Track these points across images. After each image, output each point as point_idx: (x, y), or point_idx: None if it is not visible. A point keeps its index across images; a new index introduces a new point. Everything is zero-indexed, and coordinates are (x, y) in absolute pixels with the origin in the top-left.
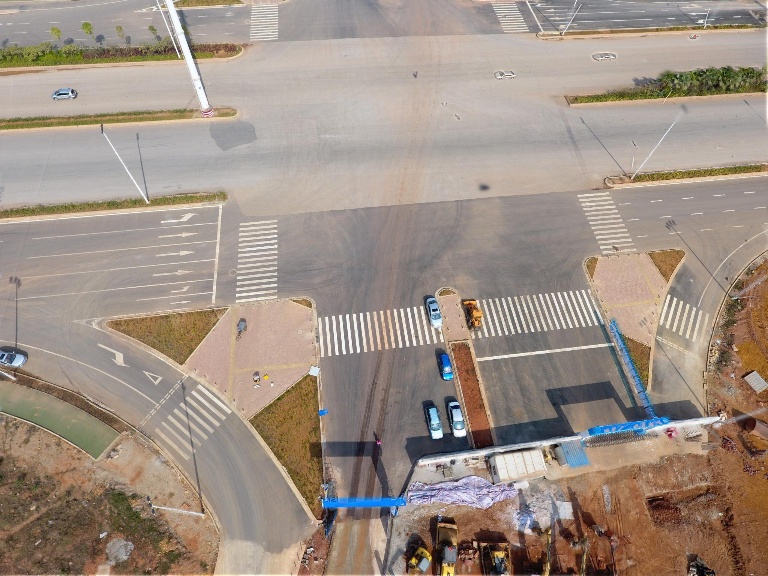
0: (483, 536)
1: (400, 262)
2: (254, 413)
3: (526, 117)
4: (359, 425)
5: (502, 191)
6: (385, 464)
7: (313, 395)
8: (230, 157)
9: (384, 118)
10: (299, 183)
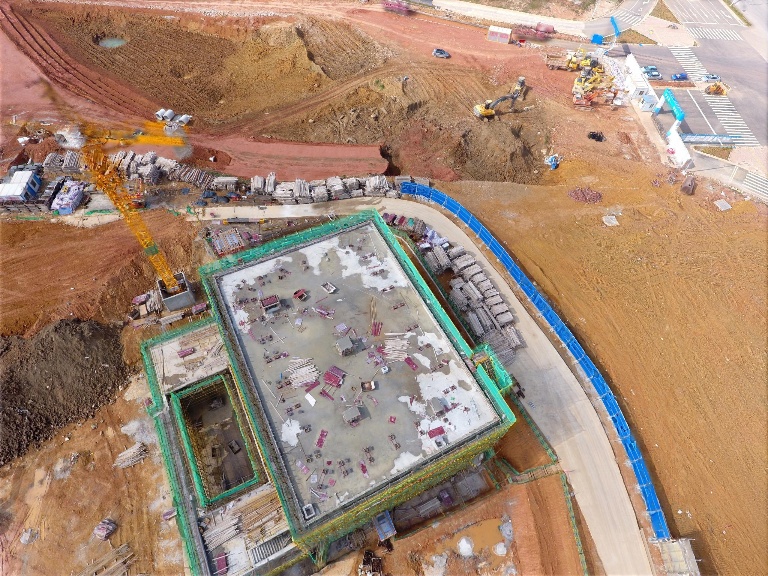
0: None
1: (739, 75)
2: None
3: None
4: (638, 53)
5: None
6: None
7: (648, 43)
8: None
9: None
10: None
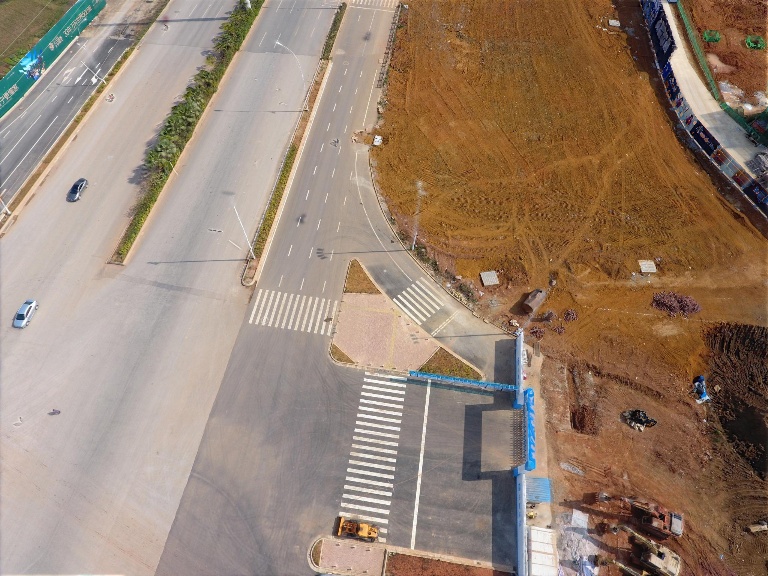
0: None
1: None
2: None
3: (110, 323)
4: None
5: (203, 408)
6: None
7: None
8: None
9: None
10: None
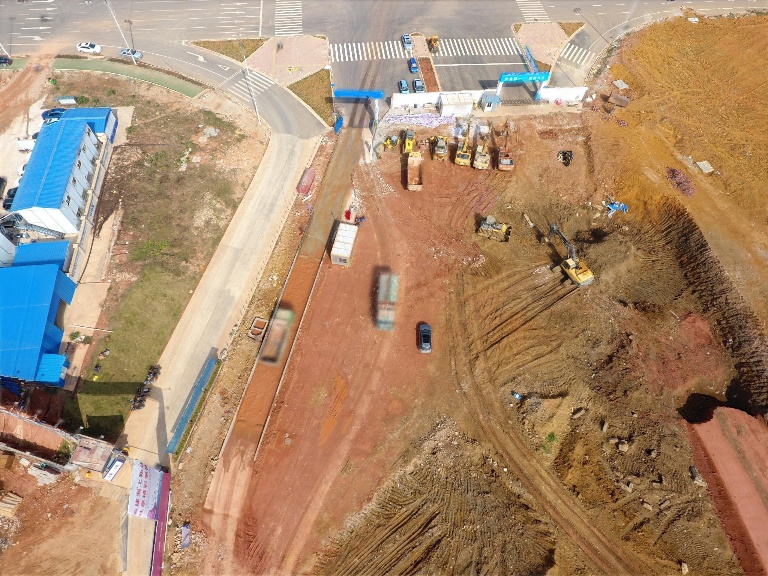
0: None
1: (385, 20)
2: (289, 84)
3: None
4: None
5: None
6: (372, 107)
7: (327, 77)
8: None
9: None
10: None
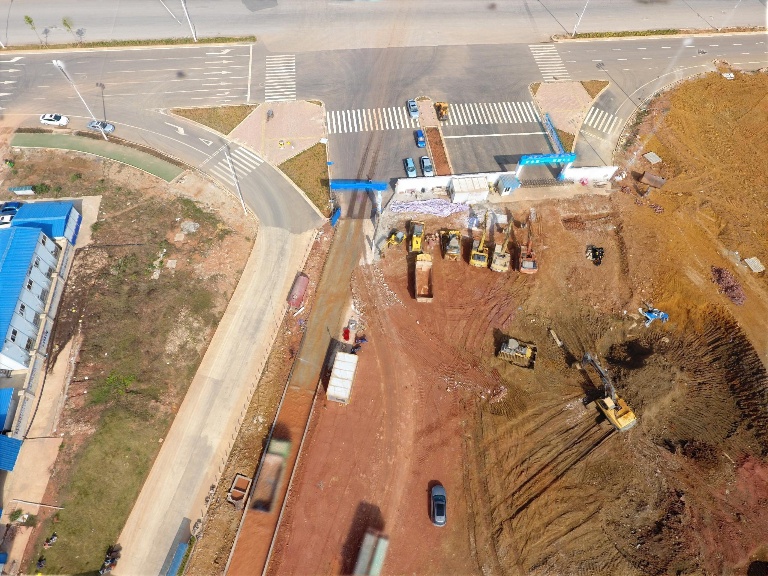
0: None
1: (388, 81)
2: (280, 162)
3: None
4: (356, 170)
5: (470, 41)
6: (374, 191)
7: (323, 154)
8: (257, 16)
9: None
10: (311, 33)
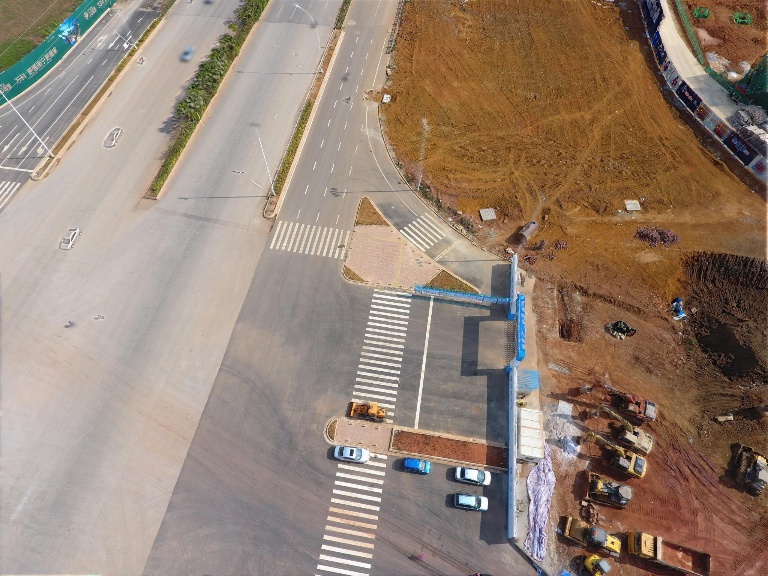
0: (578, 493)
1: (272, 470)
2: None
3: (146, 247)
4: None
5: (230, 316)
6: (502, 575)
7: None
8: None
9: (40, 411)
10: None
